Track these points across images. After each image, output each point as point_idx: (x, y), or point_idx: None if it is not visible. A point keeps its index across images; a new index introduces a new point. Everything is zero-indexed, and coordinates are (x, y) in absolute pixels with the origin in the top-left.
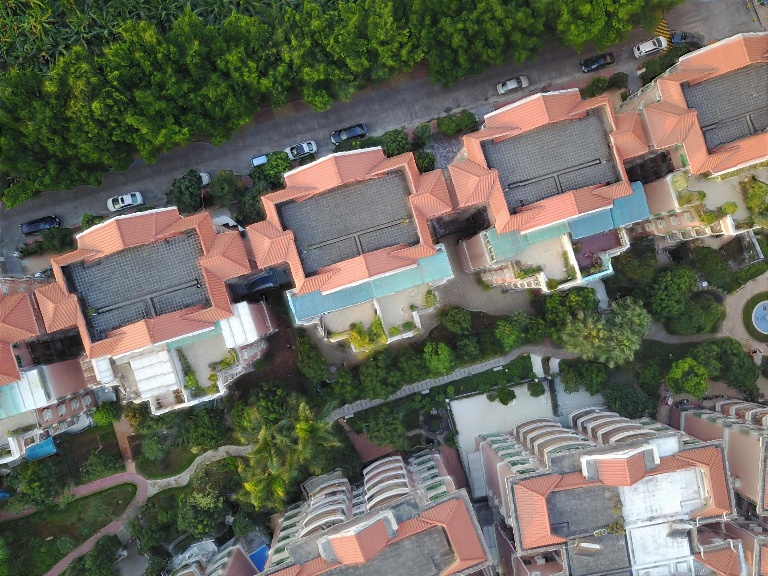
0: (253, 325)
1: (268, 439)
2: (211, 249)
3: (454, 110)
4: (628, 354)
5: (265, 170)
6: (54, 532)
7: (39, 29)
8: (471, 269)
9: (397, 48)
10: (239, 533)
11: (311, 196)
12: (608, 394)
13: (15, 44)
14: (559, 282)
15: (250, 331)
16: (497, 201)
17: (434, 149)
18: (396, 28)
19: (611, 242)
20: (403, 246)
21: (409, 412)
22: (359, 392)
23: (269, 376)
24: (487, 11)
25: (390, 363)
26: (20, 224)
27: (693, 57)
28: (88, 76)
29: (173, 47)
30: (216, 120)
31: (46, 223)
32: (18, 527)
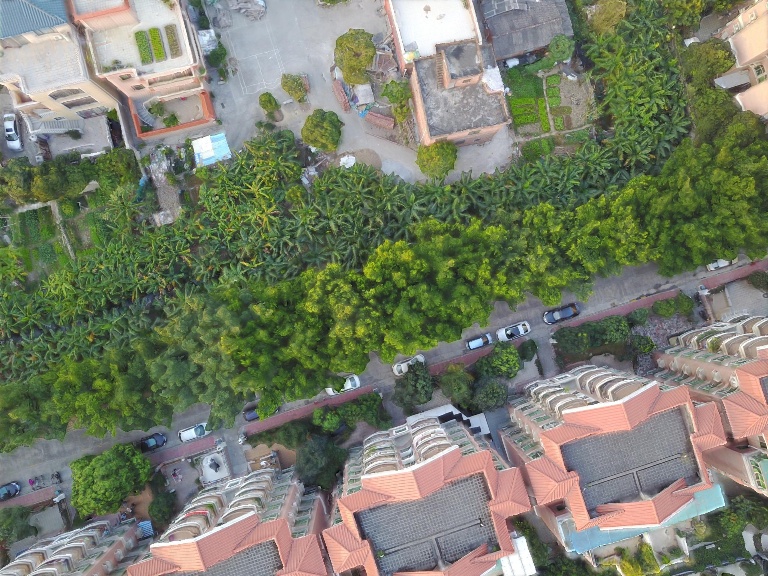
0: (531, 560)
1: None
2: (498, 492)
3: (663, 286)
4: None
5: (492, 362)
6: None
7: (265, 221)
8: None
9: (633, 248)
10: None
11: None
12: None
13: (238, 233)
14: None
15: (529, 566)
16: None
17: (644, 326)
18: None
19: None
20: (682, 482)
21: None
22: None
23: None
24: (728, 216)
25: None
26: (244, 411)
27: None
28: (347, 297)
29: (424, 262)
30: (458, 326)
31: None
32: None
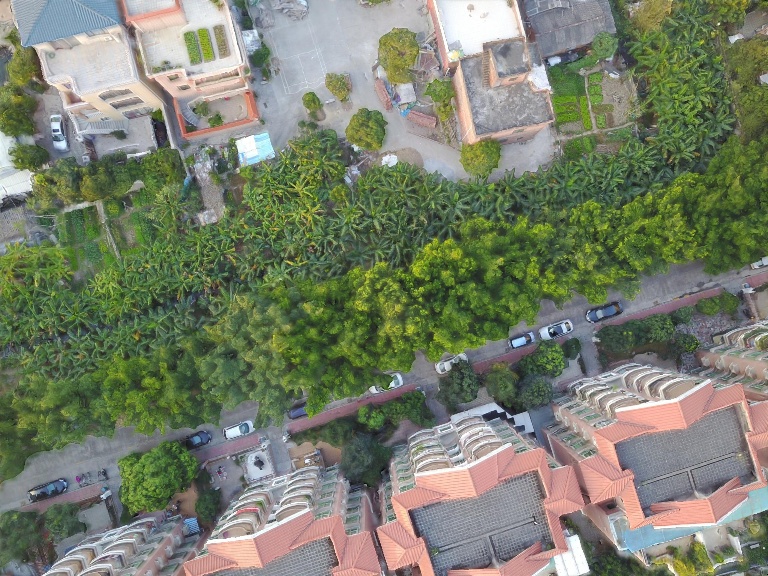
0: (584, 558)
1: None
2: (552, 490)
3: (706, 285)
4: None
5: (537, 360)
6: None
7: (309, 220)
8: None
9: (680, 246)
10: None
11: None
12: None
13: (282, 232)
14: None
15: (582, 564)
16: None
17: (687, 325)
18: None
19: None
20: (737, 481)
21: None
22: None
23: None
24: None
25: None
26: None
27: None
28: (397, 295)
29: (473, 260)
30: (505, 324)
31: None
32: None
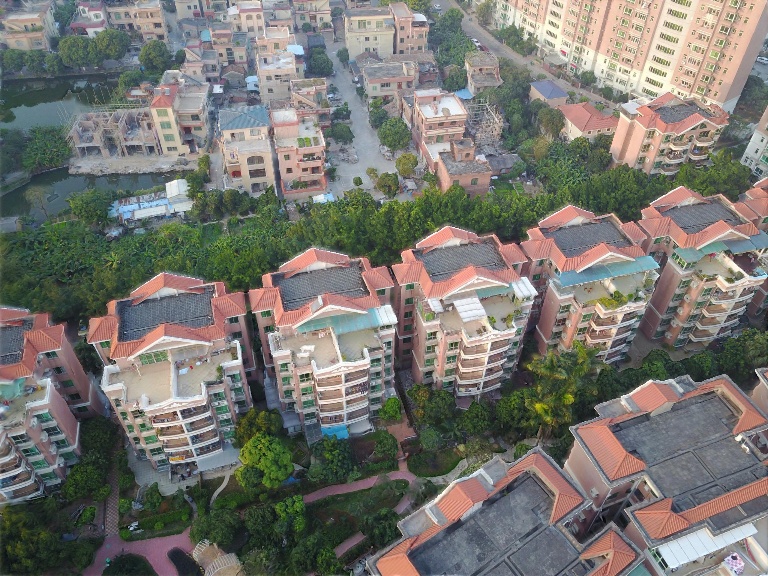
0: None
1: (554, 361)
2: None
3: None
4: None
5: None
6: (334, 517)
7: None
8: (658, 326)
9: None
10: None
11: (558, 230)
12: None
13: None
14: None
15: (532, 290)
16: (675, 231)
17: None
18: None
19: None
20: None
21: None
22: (595, 402)
23: None
24: None
25: None
26: None
27: (761, 183)
28: None
29: None
30: None
31: None
32: None
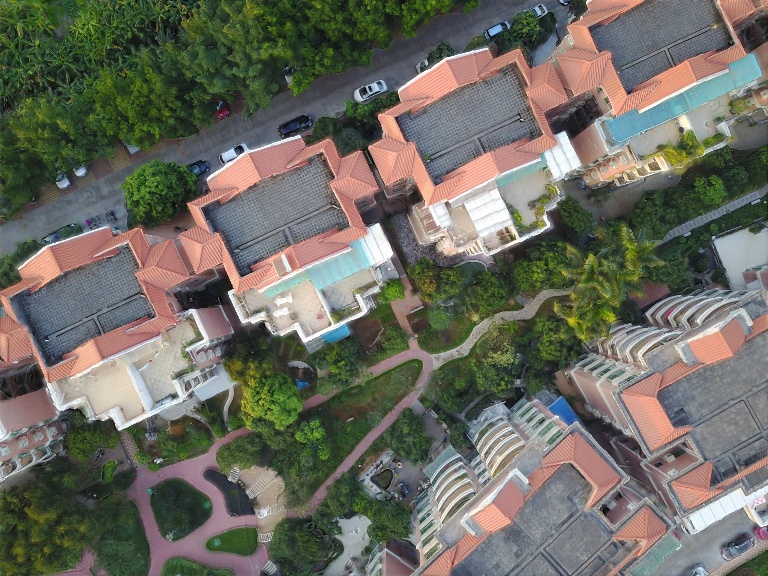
0: (575, 153)
1: (595, 267)
2: (533, 80)
3: None
4: None
5: (513, 32)
6: (353, 413)
7: None
8: None
9: None
10: (536, 388)
11: (617, 17)
12: None
13: None
14: None
15: (573, 159)
16: None
17: None
18: None
19: None
20: (715, 52)
21: None
22: None
23: (532, 240)
24: None
25: (662, 203)
26: (278, 126)
27: None
28: None
29: None
30: None
31: (301, 122)
32: (320, 412)
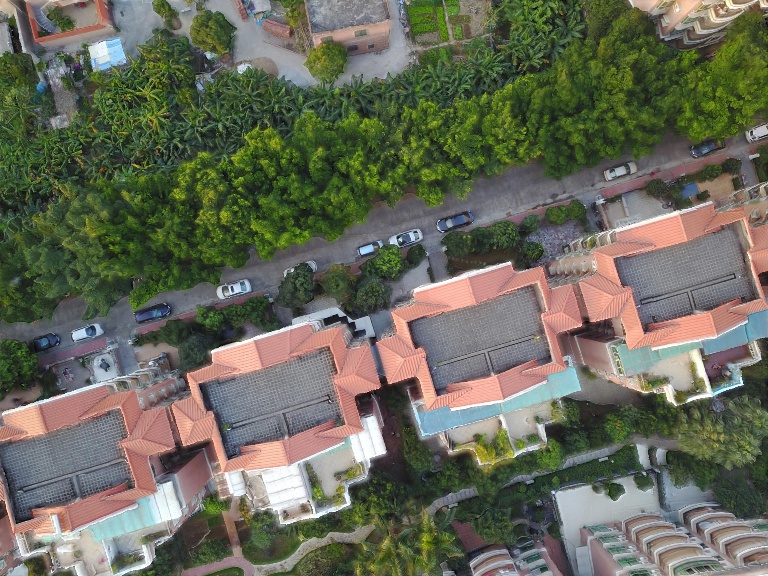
0: (382, 439)
1: (392, 549)
2: (344, 367)
3: (560, 196)
4: (750, 460)
5: (376, 263)
6: None
7: (155, 123)
8: None
9: (513, 146)
10: None
11: (441, 312)
12: (722, 493)
13: (131, 136)
14: (687, 395)
15: (379, 445)
16: (630, 318)
17: (540, 236)
18: (512, 126)
19: (741, 353)
20: (534, 363)
21: (514, 503)
22: (466, 484)
23: (374, 463)
24: (607, 110)
25: None
26: (134, 312)
27: None
28: (214, 183)
29: (295, 152)
30: (333, 220)
31: (158, 311)
32: None
